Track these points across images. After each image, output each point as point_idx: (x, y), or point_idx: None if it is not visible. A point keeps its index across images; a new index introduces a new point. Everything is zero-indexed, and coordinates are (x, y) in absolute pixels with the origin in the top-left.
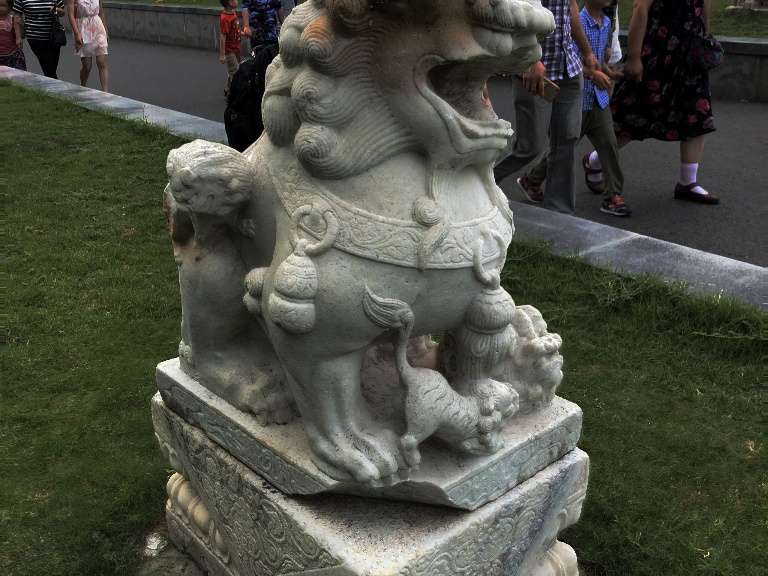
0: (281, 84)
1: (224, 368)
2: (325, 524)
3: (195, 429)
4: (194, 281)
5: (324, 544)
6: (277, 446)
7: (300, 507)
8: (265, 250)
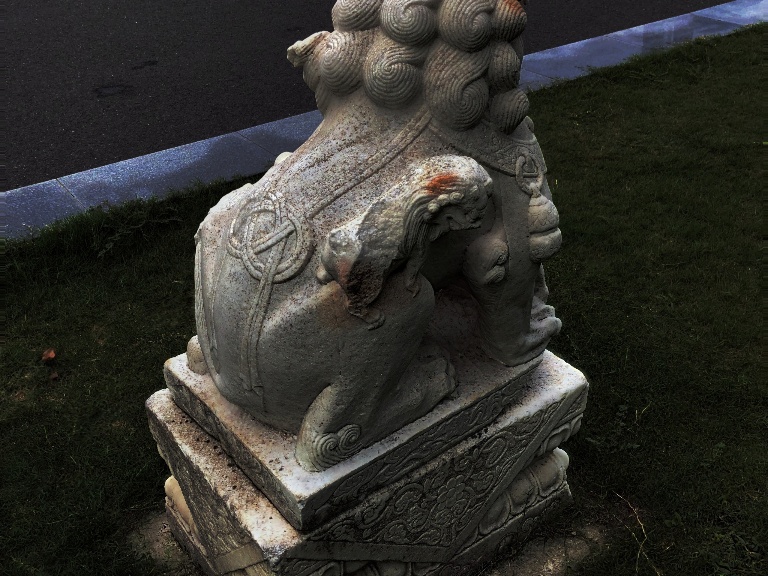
0: (481, 68)
1: (406, 394)
2: (529, 400)
3: (371, 497)
4: (409, 322)
5: (550, 402)
6: (488, 389)
7: (508, 414)
8: (465, 232)
